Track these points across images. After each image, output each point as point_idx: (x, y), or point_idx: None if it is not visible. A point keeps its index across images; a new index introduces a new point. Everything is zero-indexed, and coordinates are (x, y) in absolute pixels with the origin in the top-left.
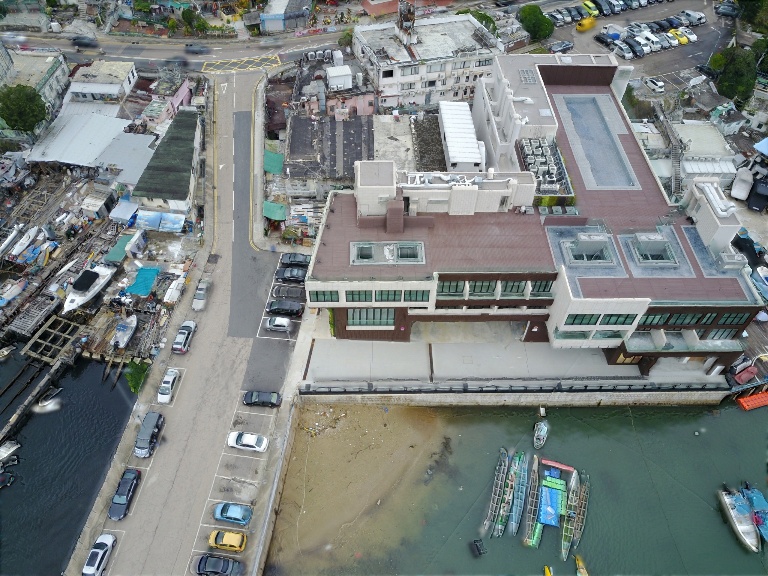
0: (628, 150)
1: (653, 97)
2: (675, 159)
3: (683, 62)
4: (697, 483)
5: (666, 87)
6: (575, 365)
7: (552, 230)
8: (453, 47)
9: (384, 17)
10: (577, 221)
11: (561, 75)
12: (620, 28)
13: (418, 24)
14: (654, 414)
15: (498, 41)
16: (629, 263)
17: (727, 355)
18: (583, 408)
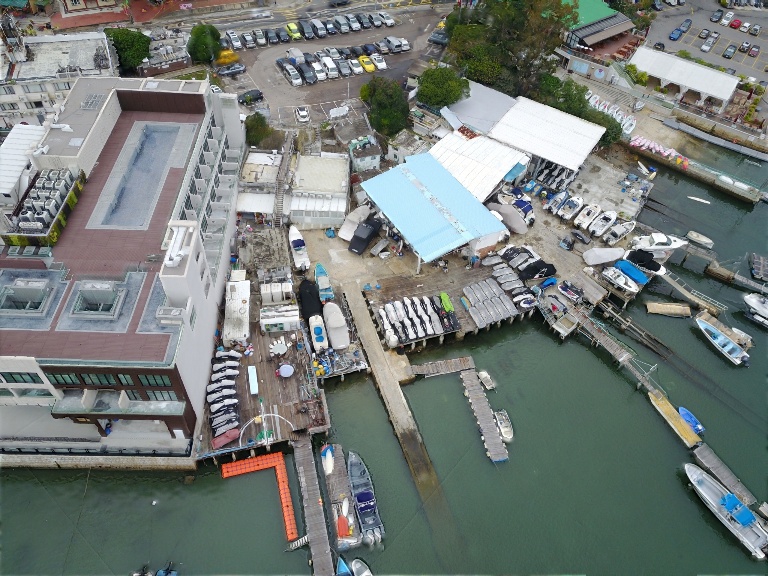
0: (168, 185)
1: (292, 127)
2: (278, 195)
3: (354, 91)
4: (121, 561)
5: (315, 117)
6: (36, 422)
7: (9, 273)
8: (63, 66)
9: (66, 31)
10: (32, 264)
11: (147, 101)
12: (298, 52)
13: (44, 40)
14: (123, 479)
15: (109, 62)
16: (63, 314)
17: (170, 419)
18: (43, 470)
